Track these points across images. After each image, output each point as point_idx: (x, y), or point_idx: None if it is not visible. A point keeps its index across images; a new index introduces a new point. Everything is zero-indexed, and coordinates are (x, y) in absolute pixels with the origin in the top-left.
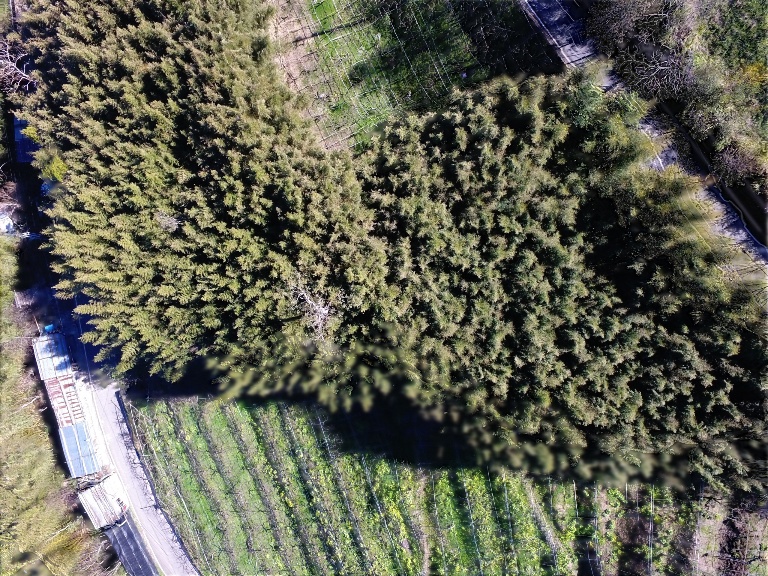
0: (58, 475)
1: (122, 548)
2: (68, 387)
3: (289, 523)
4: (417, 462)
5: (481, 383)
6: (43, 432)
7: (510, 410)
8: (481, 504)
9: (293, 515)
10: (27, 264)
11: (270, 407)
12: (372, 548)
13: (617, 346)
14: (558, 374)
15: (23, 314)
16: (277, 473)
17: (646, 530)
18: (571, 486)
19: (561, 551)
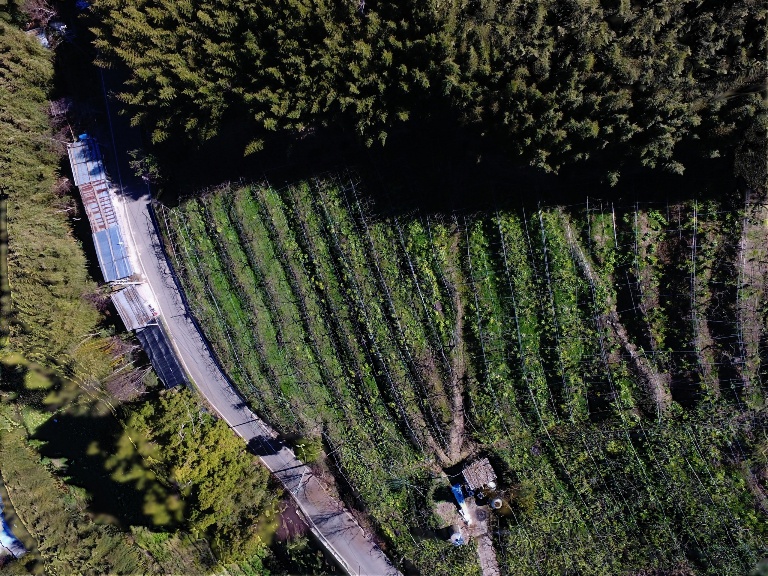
0: (91, 281)
1: (153, 352)
2: (101, 192)
3: (319, 311)
4: (451, 209)
5: (522, 60)
6: (77, 241)
7: (552, 85)
8: (516, 248)
9: (323, 300)
10: (62, 75)
11: (301, 186)
12: (404, 317)
13: (664, 1)
14: (603, 34)
15: (58, 121)
16: (308, 257)
17: (689, 246)
18: (610, 216)
19: (599, 285)
